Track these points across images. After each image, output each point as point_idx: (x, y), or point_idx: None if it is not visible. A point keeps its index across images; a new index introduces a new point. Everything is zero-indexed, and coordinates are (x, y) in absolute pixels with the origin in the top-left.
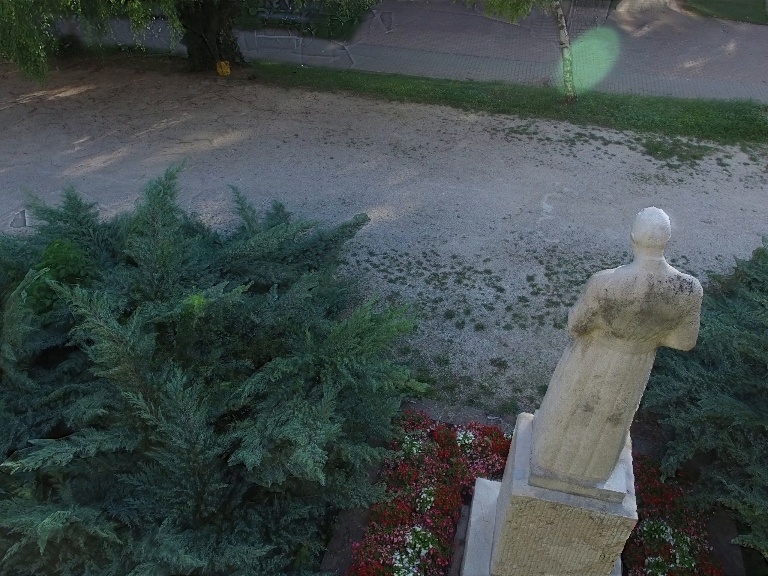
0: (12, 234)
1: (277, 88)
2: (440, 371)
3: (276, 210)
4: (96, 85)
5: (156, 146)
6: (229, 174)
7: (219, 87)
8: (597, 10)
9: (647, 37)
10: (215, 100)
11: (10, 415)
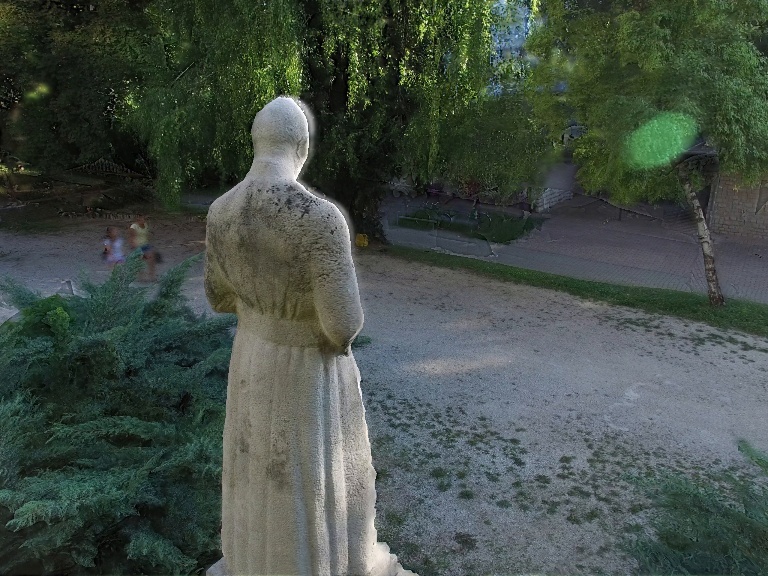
0: (48, 296)
1: (401, 260)
2: (386, 529)
3: None
4: None
5: None
6: None
7: None
8: (742, 203)
9: None
10: None
11: None
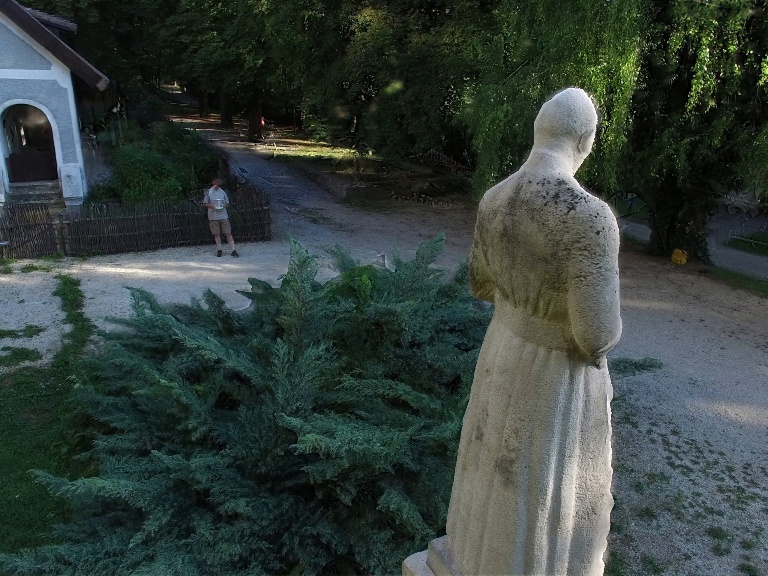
0: None
1: (723, 285)
2: (638, 573)
3: None
4: None
5: None
6: None
7: (662, 269)
8: None
9: None
10: (647, 275)
11: None
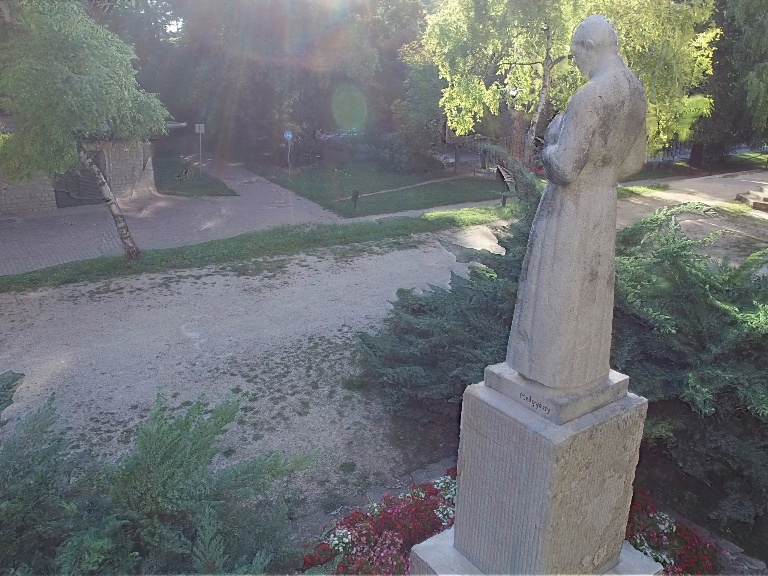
0: None
1: None
2: None
3: None
4: None
5: None
6: None
7: None
8: (133, 162)
9: (151, 217)
10: None
11: None
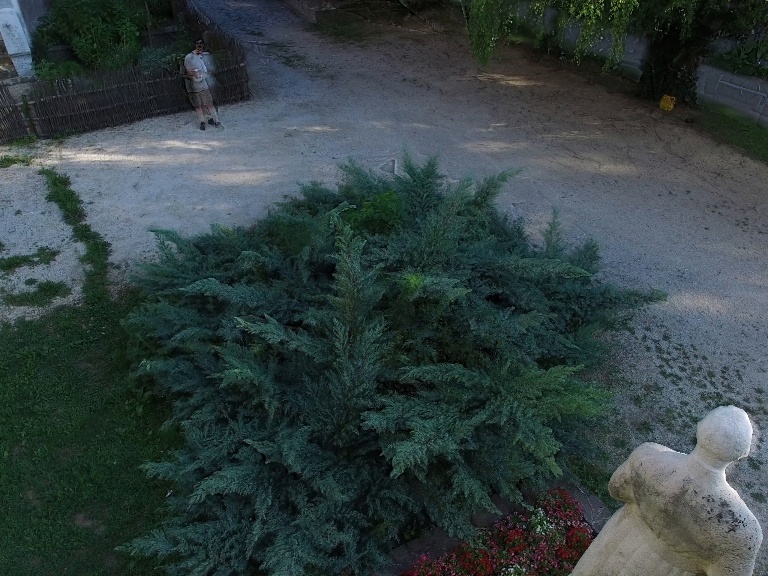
0: (376, 173)
1: (708, 139)
2: None
3: (586, 248)
4: (545, 82)
5: (551, 151)
6: (592, 200)
7: (650, 119)
8: None
9: None
10: (636, 130)
11: (285, 295)
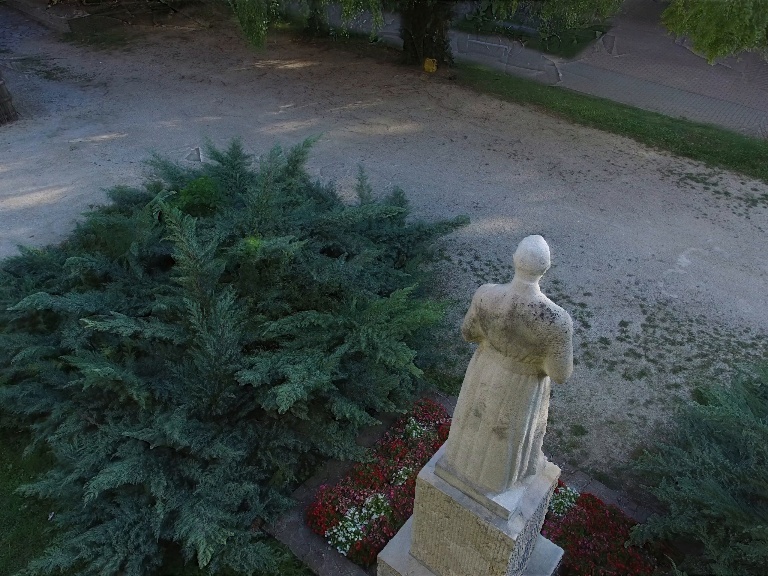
0: (184, 164)
1: (471, 91)
2: None
3: (394, 195)
4: (320, 62)
5: (342, 122)
6: (388, 158)
7: (420, 81)
8: None
9: None
10: (410, 92)
11: (122, 295)
